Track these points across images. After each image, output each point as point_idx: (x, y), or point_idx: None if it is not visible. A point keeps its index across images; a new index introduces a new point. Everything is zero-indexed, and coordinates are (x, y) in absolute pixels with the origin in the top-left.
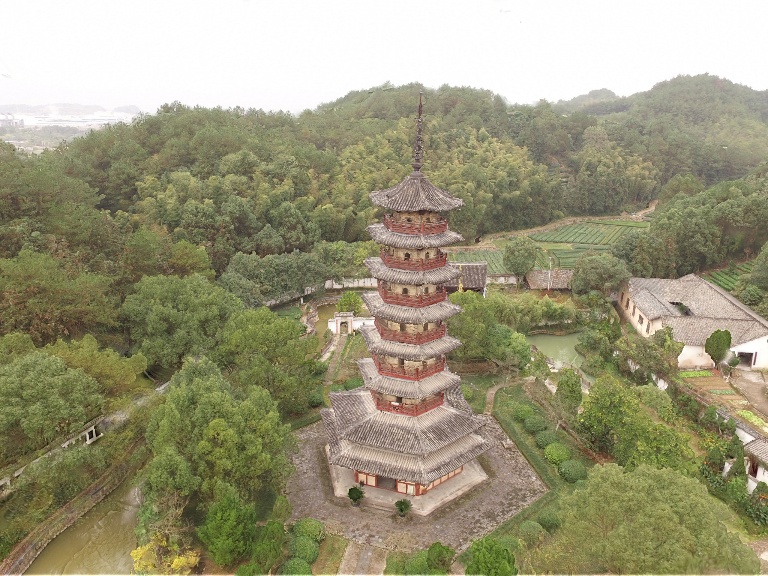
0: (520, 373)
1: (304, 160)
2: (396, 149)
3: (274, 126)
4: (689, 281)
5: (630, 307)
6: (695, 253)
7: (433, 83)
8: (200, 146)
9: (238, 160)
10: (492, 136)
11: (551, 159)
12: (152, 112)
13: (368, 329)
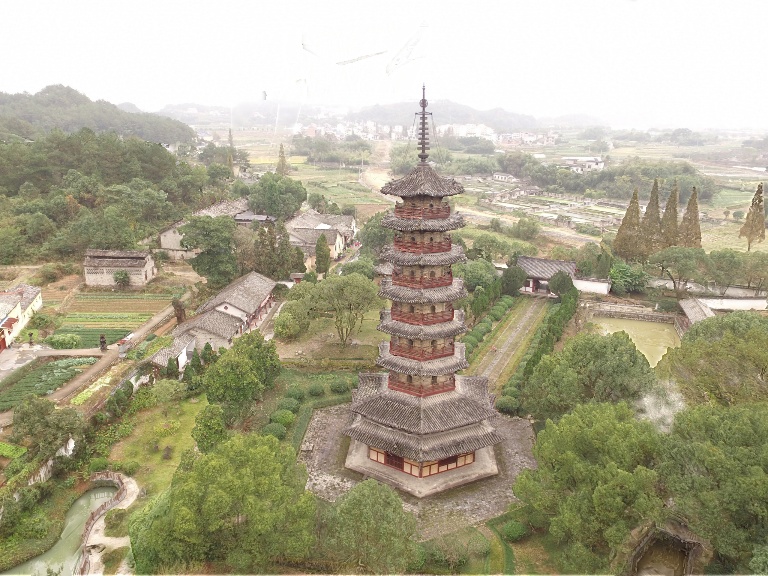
0: None
1: None
2: None
3: None
4: None
5: None
6: None
7: None
8: None
9: None
10: None
11: None
12: None
13: None
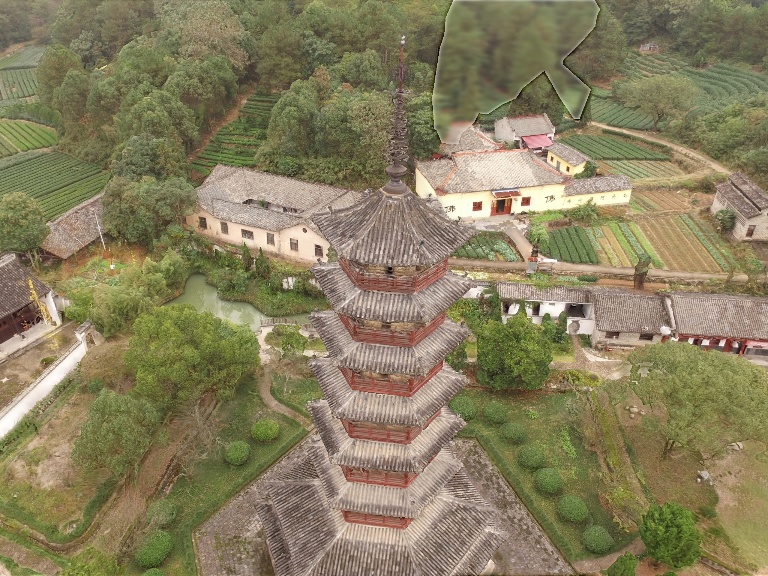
0: None
1: None
2: None
3: None
4: (234, 174)
5: (213, 226)
6: (185, 140)
7: None
8: None
9: None
10: None
11: None
12: None
13: (346, 452)
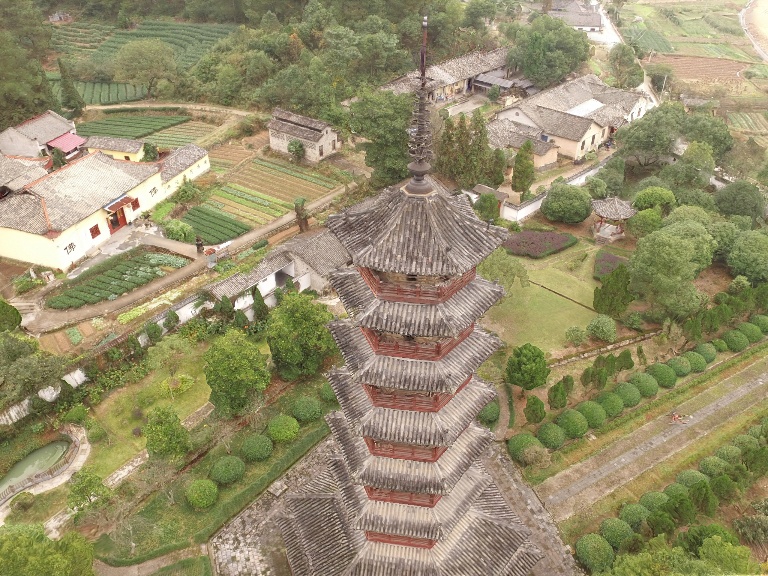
0: None
1: None
2: None
3: None
4: None
5: None
6: None
7: None
8: None
9: None
10: None
11: None
12: None
13: (444, 476)
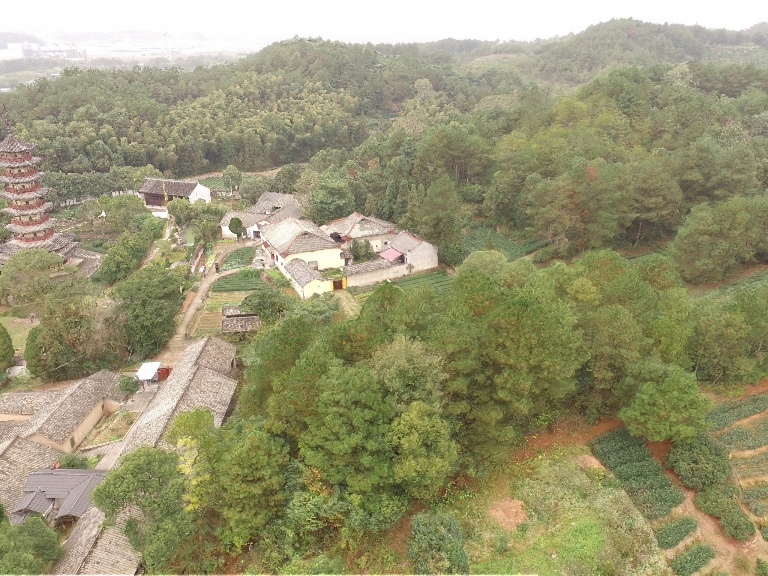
0: (154, 239)
1: (133, 111)
2: (228, 101)
3: (163, 80)
4: None
5: None
6: None
7: (320, 39)
8: (63, 102)
9: (84, 112)
10: (341, 87)
11: (391, 105)
12: (49, 76)
13: None
